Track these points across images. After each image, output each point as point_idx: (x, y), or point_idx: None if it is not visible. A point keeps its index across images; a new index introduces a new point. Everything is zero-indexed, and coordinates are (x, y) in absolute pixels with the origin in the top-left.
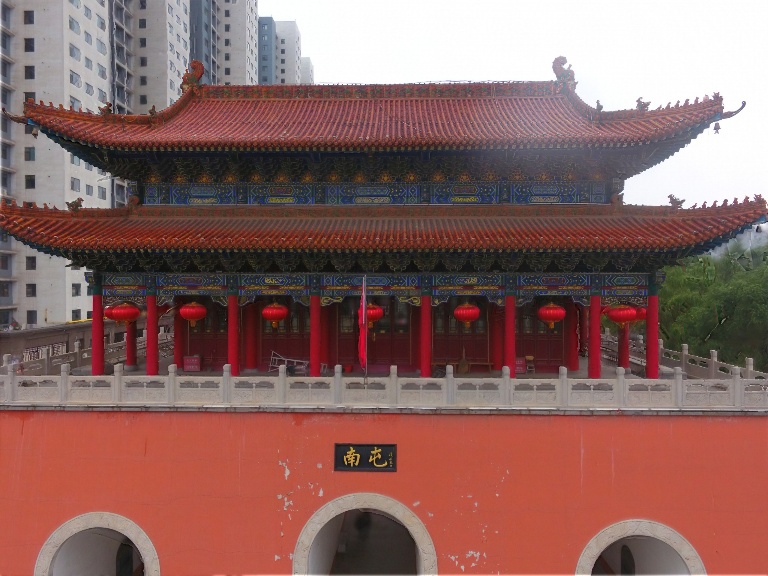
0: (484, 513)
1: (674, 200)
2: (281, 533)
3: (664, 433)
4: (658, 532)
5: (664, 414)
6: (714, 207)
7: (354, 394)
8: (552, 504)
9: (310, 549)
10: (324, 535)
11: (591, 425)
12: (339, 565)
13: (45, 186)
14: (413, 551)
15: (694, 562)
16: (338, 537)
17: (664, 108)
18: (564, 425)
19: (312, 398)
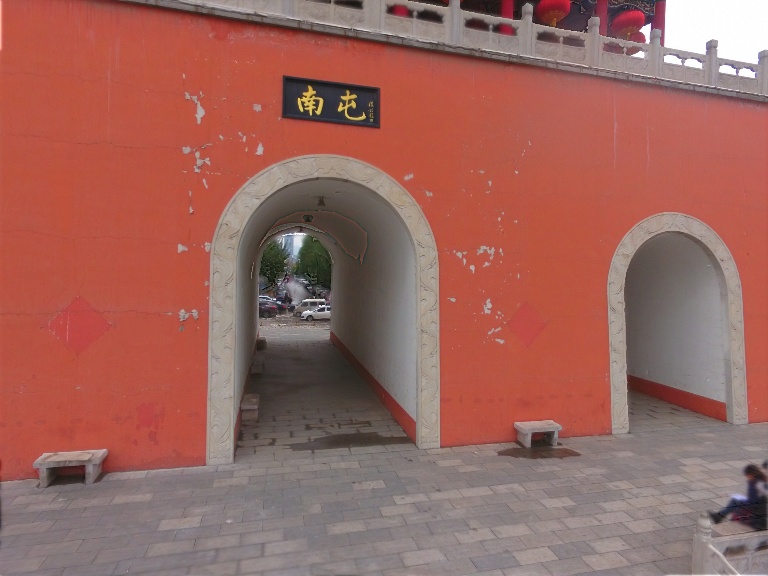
0: (500, 195)
1: None
2: (189, 209)
3: (699, 114)
4: (694, 228)
5: (700, 90)
6: None
7: (314, 8)
8: (582, 189)
9: (240, 241)
10: (245, 297)
11: (626, 94)
12: (256, 380)
13: None
14: (353, 368)
15: (728, 264)
16: (251, 357)
17: None
18: (595, 91)
19: (244, 3)
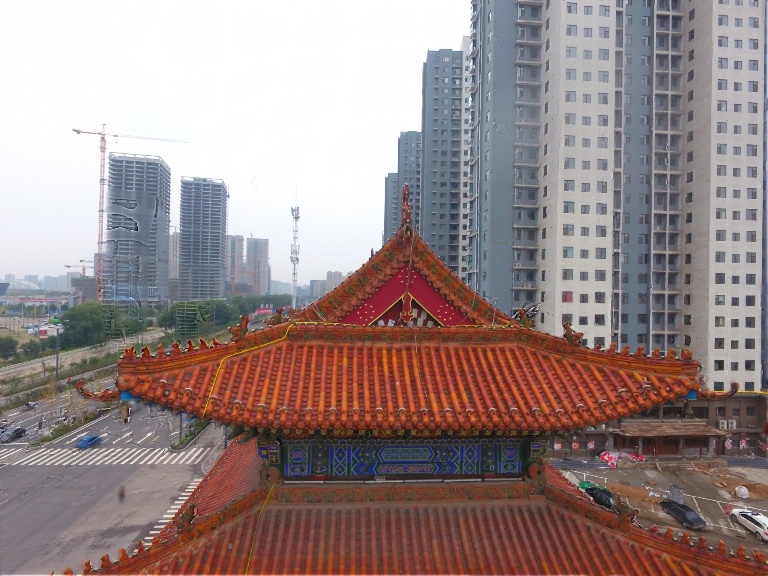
0: None
1: (186, 514)
2: None
3: None
4: None
5: None
6: (121, 559)
7: None
8: None
9: None
10: None
11: None
12: None
13: (548, 279)
14: None
15: None
16: None
17: (207, 347)
18: None
19: None
